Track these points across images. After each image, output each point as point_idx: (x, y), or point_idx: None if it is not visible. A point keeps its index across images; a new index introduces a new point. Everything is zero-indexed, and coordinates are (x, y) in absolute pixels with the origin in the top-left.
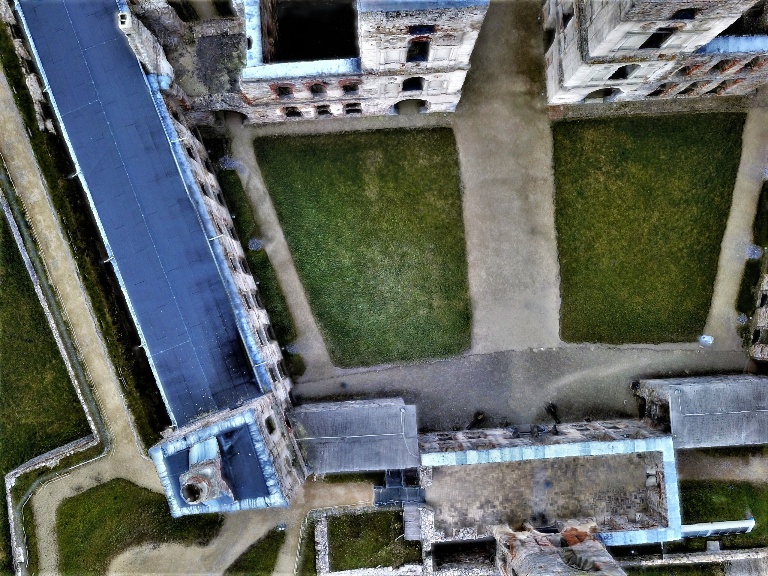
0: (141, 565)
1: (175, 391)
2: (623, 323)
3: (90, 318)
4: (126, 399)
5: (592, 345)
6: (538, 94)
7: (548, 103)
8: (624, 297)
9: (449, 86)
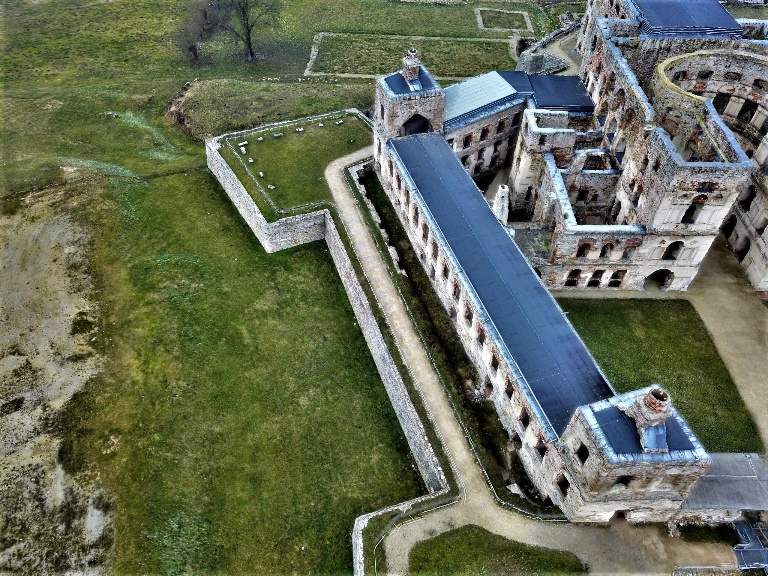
0: None
1: (553, 410)
2: None
3: (438, 389)
4: (473, 454)
5: None
6: (744, 285)
7: (755, 289)
8: None
9: (695, 256)
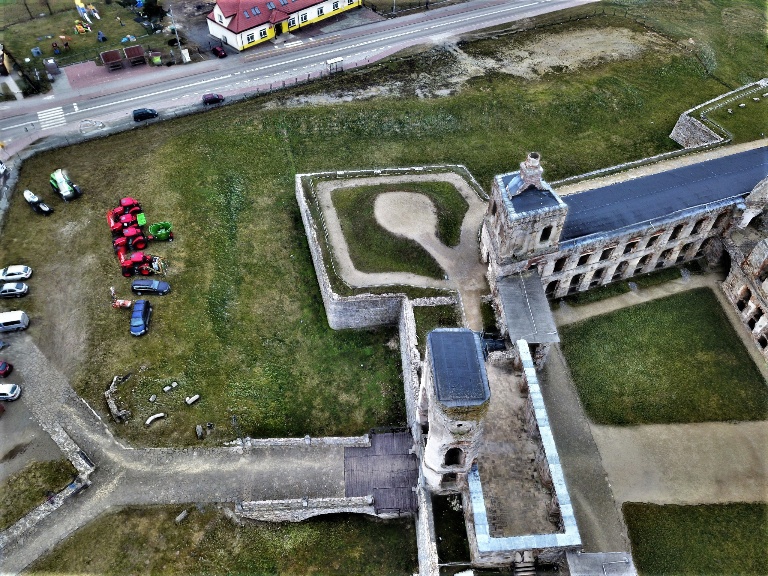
0: (423, 207)
1: None
2: (658, 569)
3: None
4: None
5: (626, 534)
6: None
7: None
8: (685, 571)
9: None
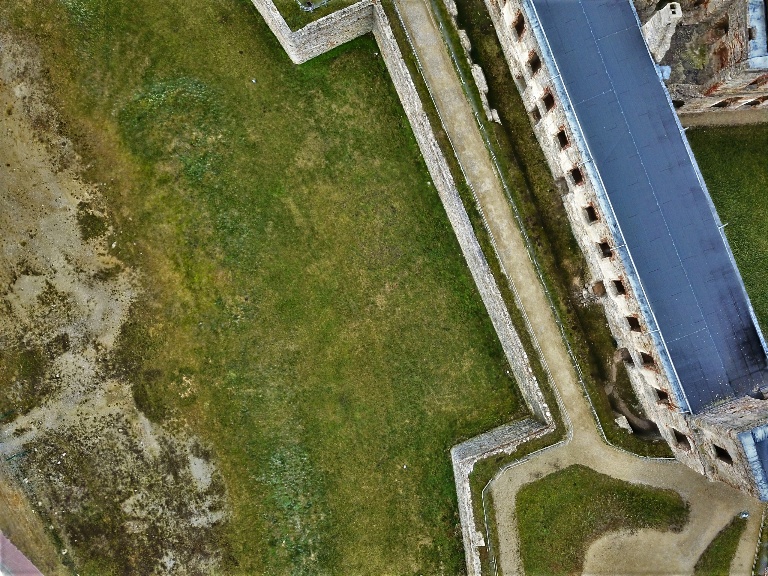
0: (620, 550)
1: (691, 378)
2: None
3: (544, 306)
4: (582, 386)
5: None
6: None
7: None
8: None
9: None
